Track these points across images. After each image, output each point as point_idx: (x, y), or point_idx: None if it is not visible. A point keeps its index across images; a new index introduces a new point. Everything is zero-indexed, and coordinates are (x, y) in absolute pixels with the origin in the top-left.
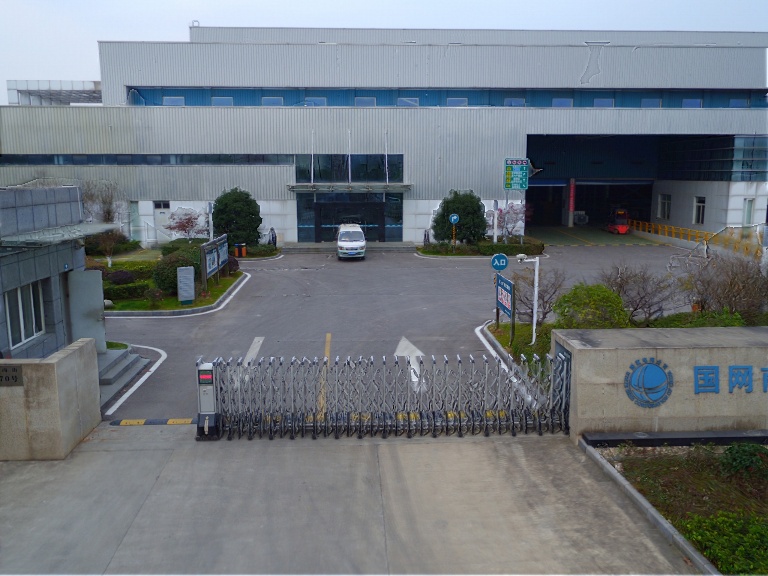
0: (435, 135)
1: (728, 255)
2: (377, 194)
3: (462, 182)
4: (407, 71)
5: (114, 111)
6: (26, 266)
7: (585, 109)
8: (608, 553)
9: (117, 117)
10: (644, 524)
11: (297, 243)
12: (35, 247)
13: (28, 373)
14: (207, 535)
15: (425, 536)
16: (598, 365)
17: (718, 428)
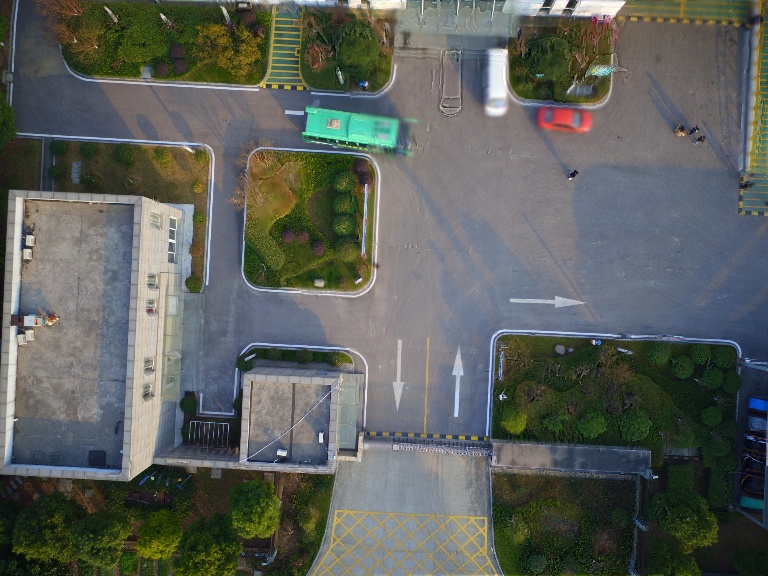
0: None
1: None
2: None
3: None
4: None
5: None
6: None
7: None
8: (477, 506)
9: None
10: (488, 498)
11: (406, 10)
12: None
13: None
14: (402, 492)
15: (444, 497)
16: None
17: None
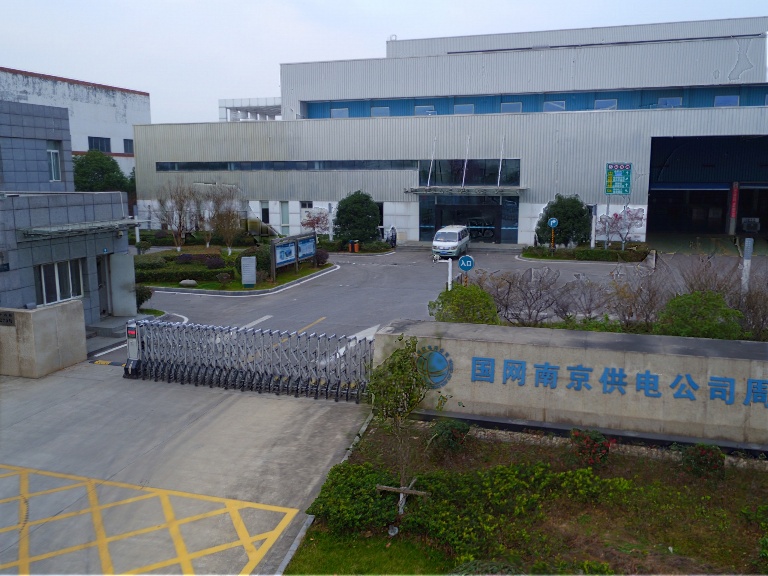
0: (553, 140)
1: (692, 266)
2: (494, 197)
3: (580, 186)
4: (551, 75)
5: (272, 125)
6: (59, 248)
7: (720, 109)
8: (278, 480)
9: (274, 130)
10: None
11: (418, 242)
12: (46, 235)
13: (18, 318)
14: (58, 429)
15: (178, 451)
16: (391, 348)
17: (492, 414)
